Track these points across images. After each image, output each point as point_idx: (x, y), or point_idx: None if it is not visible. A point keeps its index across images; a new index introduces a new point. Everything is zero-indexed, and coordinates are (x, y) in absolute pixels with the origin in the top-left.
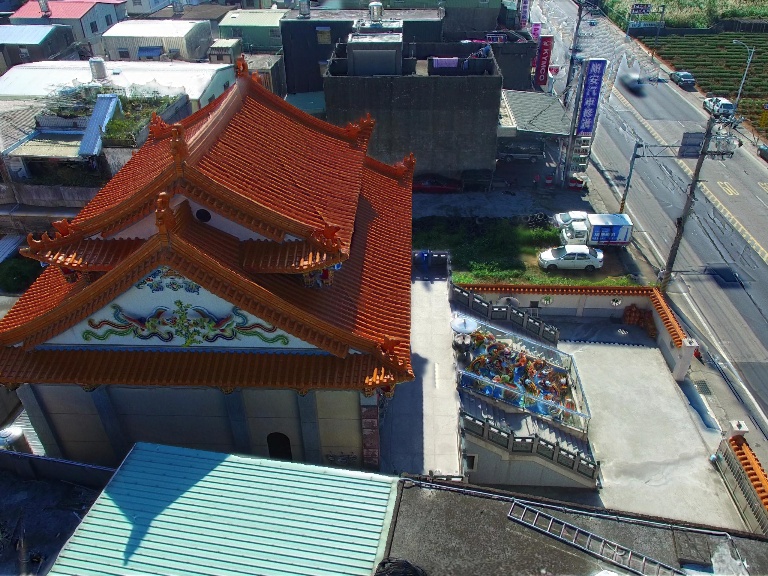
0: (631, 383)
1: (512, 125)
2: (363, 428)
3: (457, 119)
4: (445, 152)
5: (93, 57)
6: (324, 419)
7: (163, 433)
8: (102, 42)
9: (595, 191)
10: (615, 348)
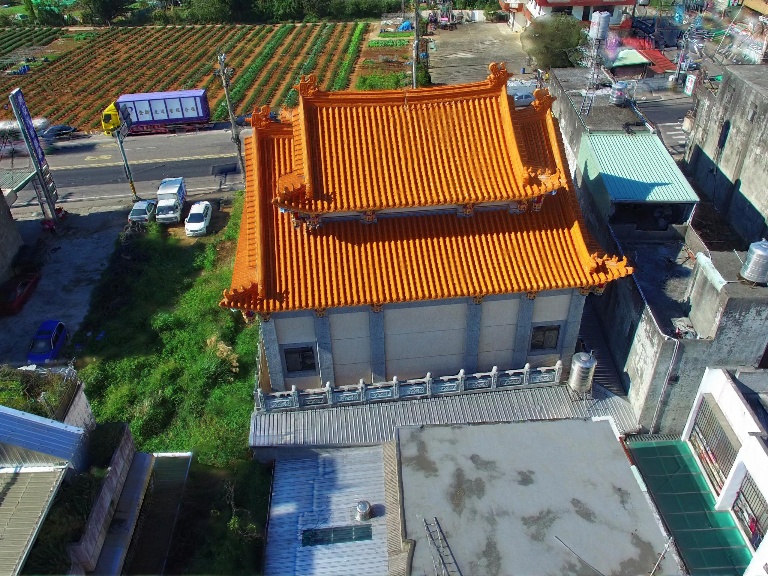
0: None
1: (4, 191)
2: None
3: None
4: None
5: None
6: None
7: None
8: None
9: (71, 210)
10: None
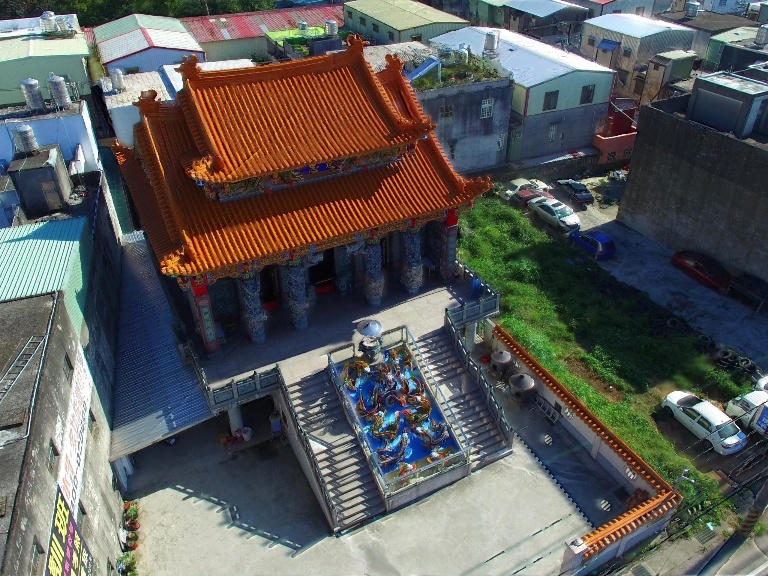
0: (513, 531)
1: None
2: None
3: (761, 207)
4: (736, 241)
5: (491, 31)
6: None
7: None
8: (582, 27)
9: None
10: (564, 503)
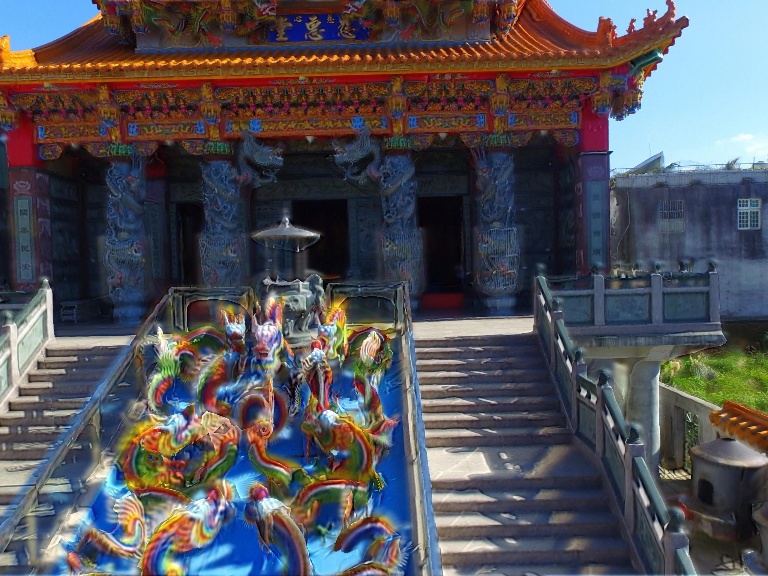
0: None
1: None
2: None
3: None
4: None
5: None
6: None
7: None
8: None
9: None
10: None
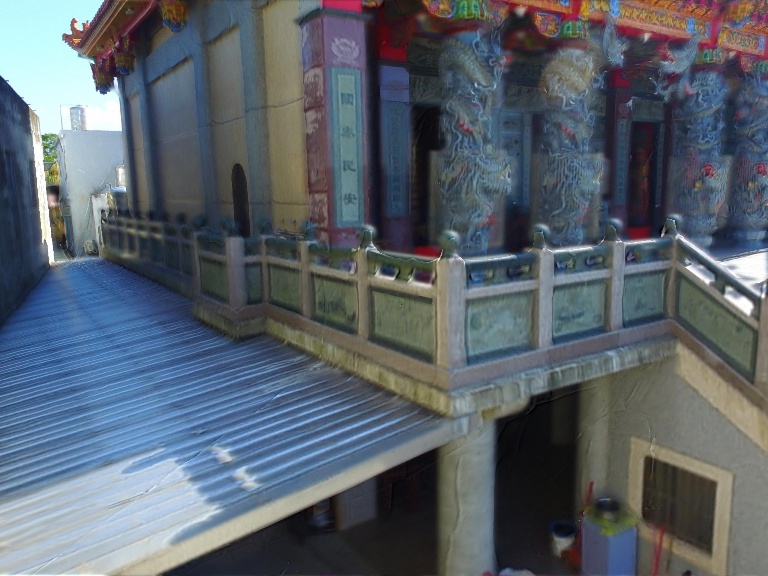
0: None
1: None
2: (306, 111)
3: None
4: None
5: None
6: (276, 109)
7: (177, 183)
8: None
9: None
10: None
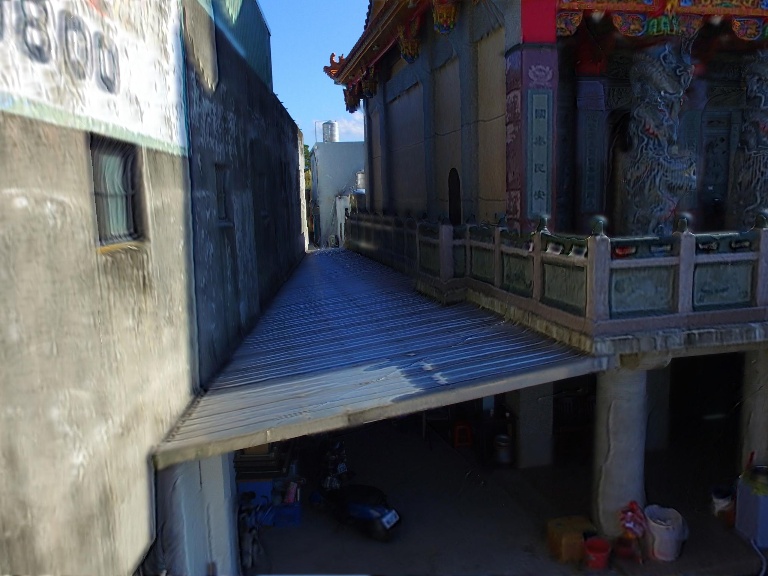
0: None
1: None
2: (507, 125)
3: None
4: None
5: None
6: (485, 123)
7: None
8: None
9: None
10: None
